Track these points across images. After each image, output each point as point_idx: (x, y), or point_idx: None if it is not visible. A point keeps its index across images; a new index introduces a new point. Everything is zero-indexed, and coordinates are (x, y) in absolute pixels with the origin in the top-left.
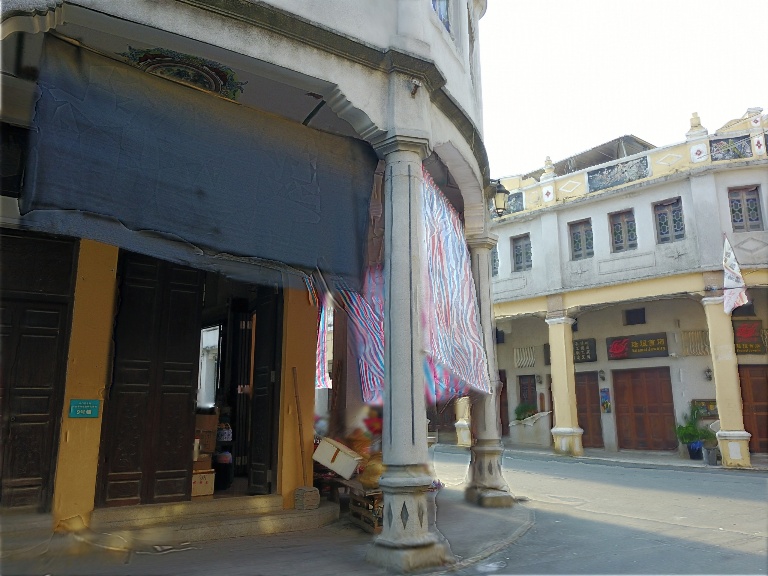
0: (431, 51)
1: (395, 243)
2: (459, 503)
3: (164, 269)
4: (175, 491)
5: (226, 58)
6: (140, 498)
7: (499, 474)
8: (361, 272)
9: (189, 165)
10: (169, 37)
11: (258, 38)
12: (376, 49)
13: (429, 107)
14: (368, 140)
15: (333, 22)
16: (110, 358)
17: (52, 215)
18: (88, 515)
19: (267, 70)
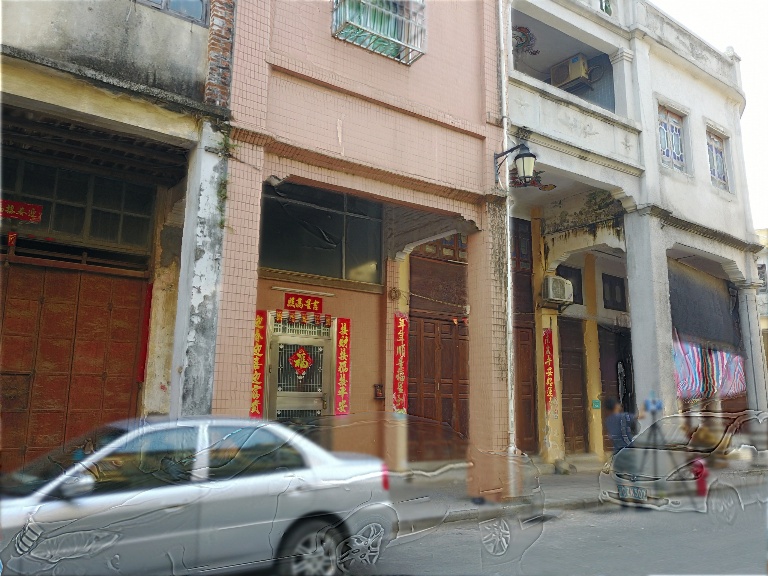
0: None
1: (752, 333)
2: None
3: (605, 333)
4: (624, 445)
5: (705, 254)
6: (615, 447)
7: None
8: (736, 345)
9: (694, 302)
10: (696, 250)
11: (717, 246)
12: (747, 243)
13: None
14: (733, 282)
15: (731, 231)
16: (600, 380)
17: (578, 309)
18: (604, 454)
19: (714, 257)
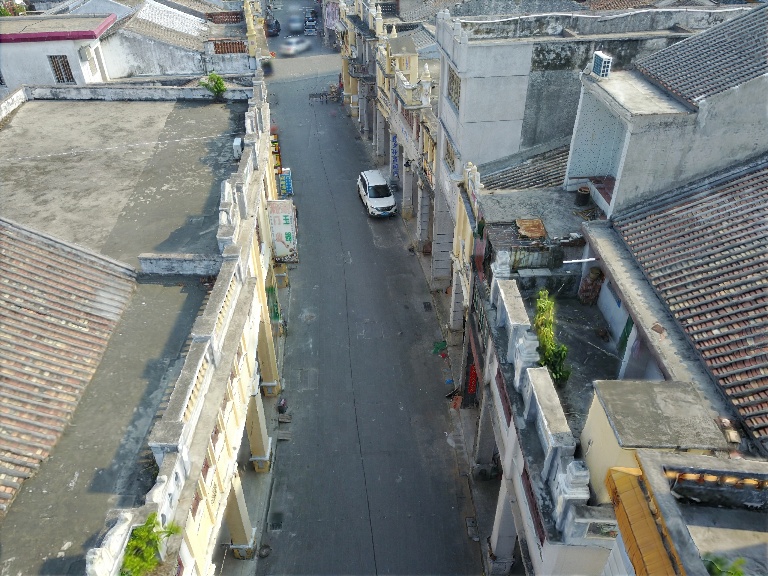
0: None
1: None
2: None
3: None
4: None
5: None
6: None
7: None
8: None
9: None
10: None
11: None
12: None
13: None
14: None
15: None
16: None
17: None
18: None
19: None
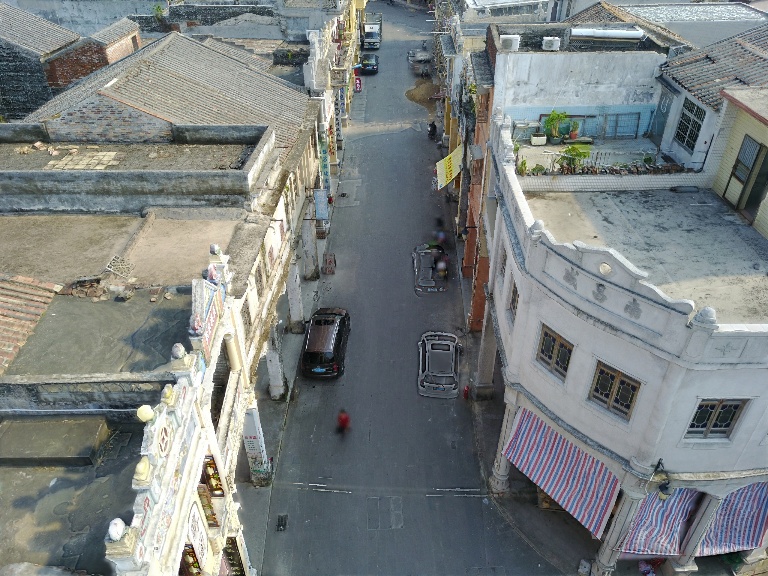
0: (527, 376)
1: None
2: (589, 552)
3: None
4: None
5: None
6: None
7: (597, 570)
8: None
9: None
10: None
11: None
12: None
13: (515, 393)
14: None
15: None
16: None
17: None
18: None
19: None
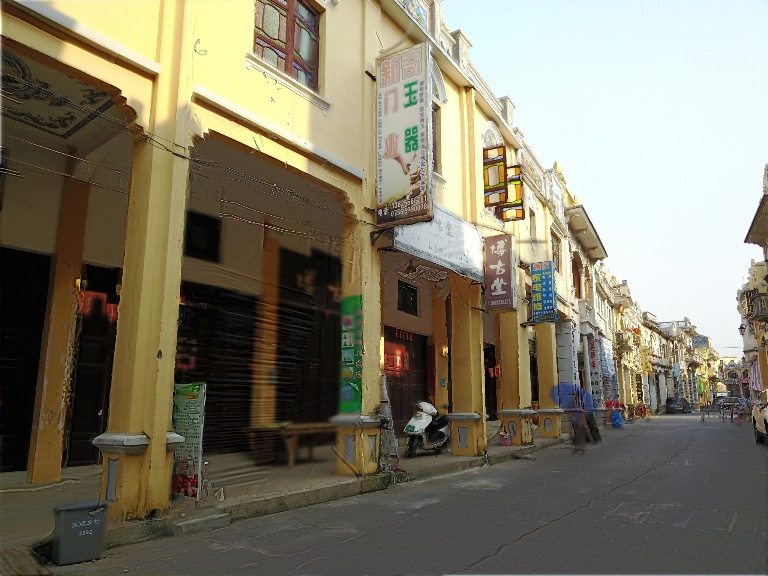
0: None
1: None
2: None
3: None
4: None
5: None
6: None
7: None
8: None
9: None
10: None
11: None
12: None
13: (747, 355)
14: None
15: None
16: None
17: None
18: None
19: None
